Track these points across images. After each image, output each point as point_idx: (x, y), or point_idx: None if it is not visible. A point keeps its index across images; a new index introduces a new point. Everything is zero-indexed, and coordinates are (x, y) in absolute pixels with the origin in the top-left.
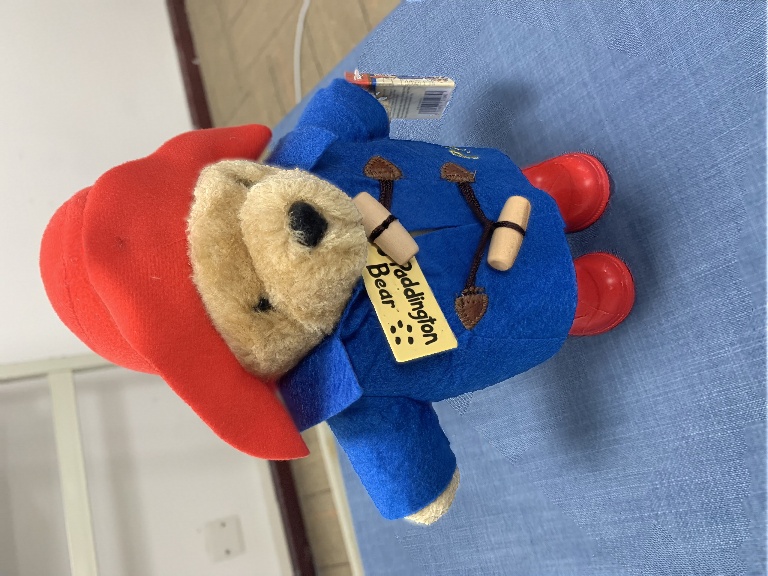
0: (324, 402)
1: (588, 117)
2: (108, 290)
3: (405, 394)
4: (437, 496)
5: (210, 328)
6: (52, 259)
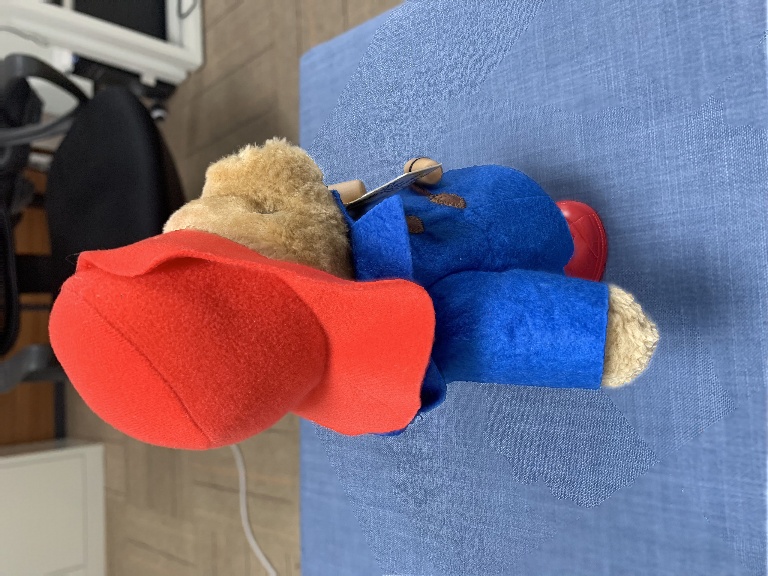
0: (396, 262)
1: None
2: (118, 254)
3: (474, 261)
4: (605, 286)
5: (232, 242)
6: (63, 325)
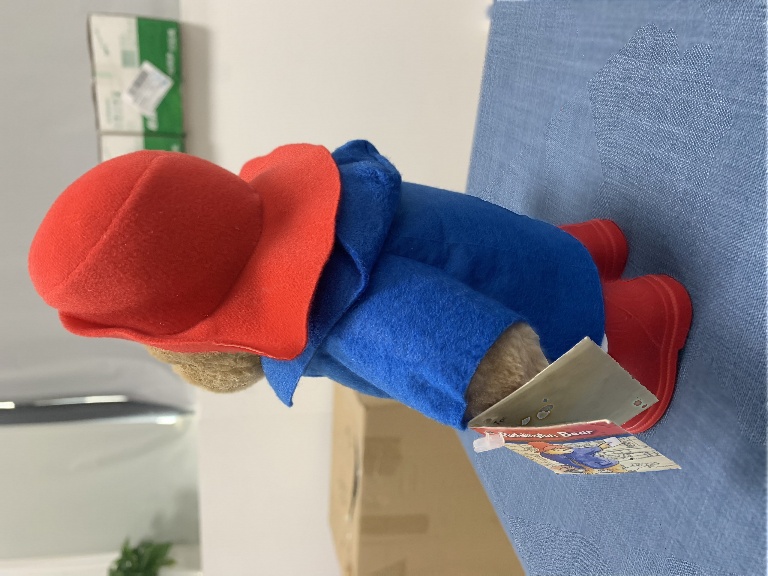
0: None
1: (668, 473)
2: None
3: None
4: None
5: None
6: None
